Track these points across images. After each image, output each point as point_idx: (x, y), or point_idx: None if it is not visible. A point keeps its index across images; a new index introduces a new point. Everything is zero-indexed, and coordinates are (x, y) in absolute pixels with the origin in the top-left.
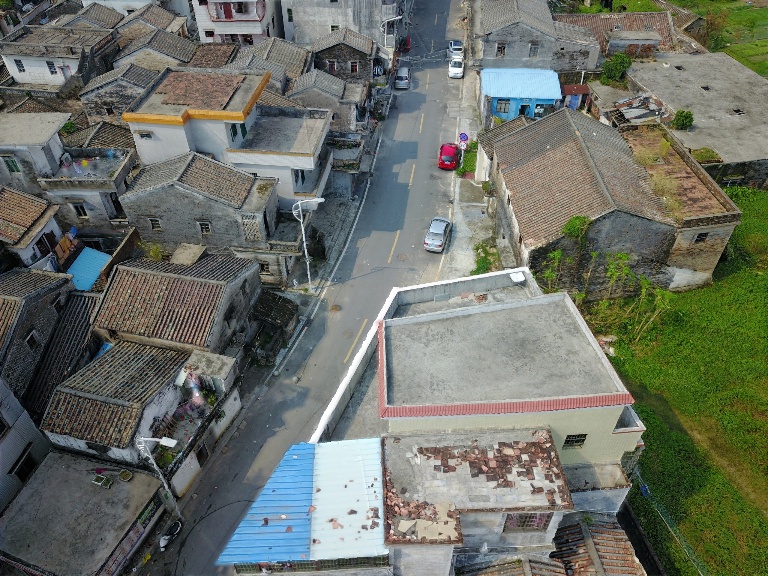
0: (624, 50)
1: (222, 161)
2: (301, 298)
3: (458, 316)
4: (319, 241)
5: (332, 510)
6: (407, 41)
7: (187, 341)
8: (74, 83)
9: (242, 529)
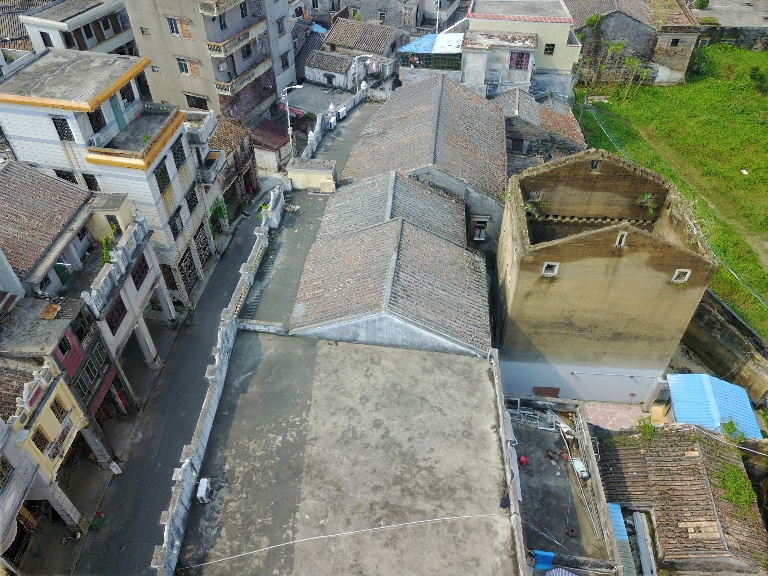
0: None
1: None
2: None
3: (508, 1)
4: None
5: (442, 45)
6: None
7: (372, 50)
8: None
9: (406, 46)
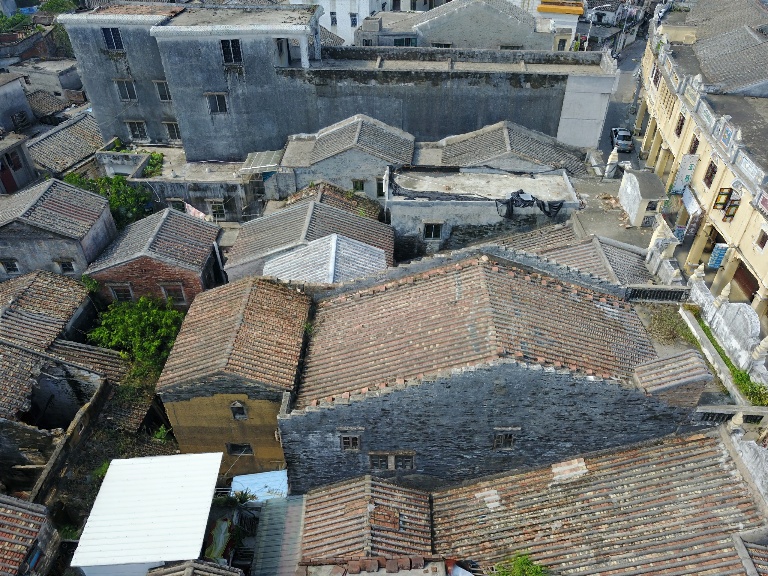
0: None
1: None
2: None
3: None
4: None
5: None
6: None
7: (625, 1)
8: None
9: None
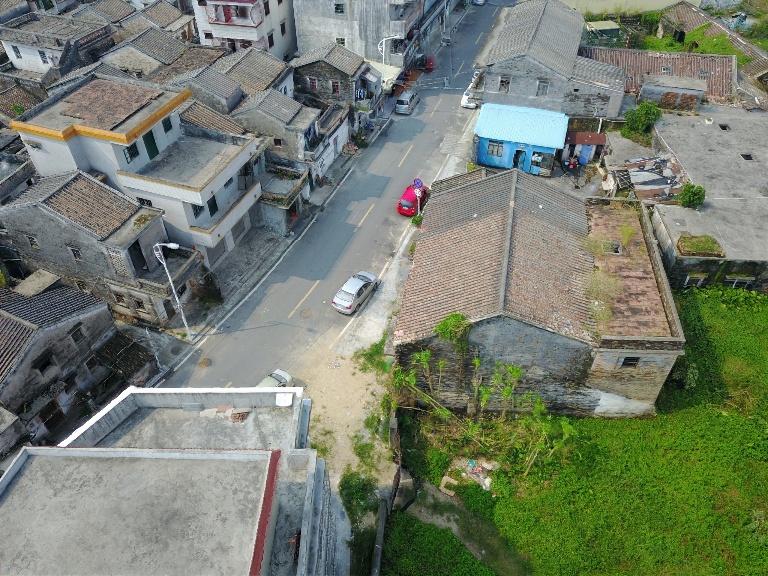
0: (660, 98)
1: (116, 183)
2: (175, 344)
3: (123, 457)
4: (212, 283)
5: None
6: (424, 61)
7: None
8: (53, 75)
9: None
